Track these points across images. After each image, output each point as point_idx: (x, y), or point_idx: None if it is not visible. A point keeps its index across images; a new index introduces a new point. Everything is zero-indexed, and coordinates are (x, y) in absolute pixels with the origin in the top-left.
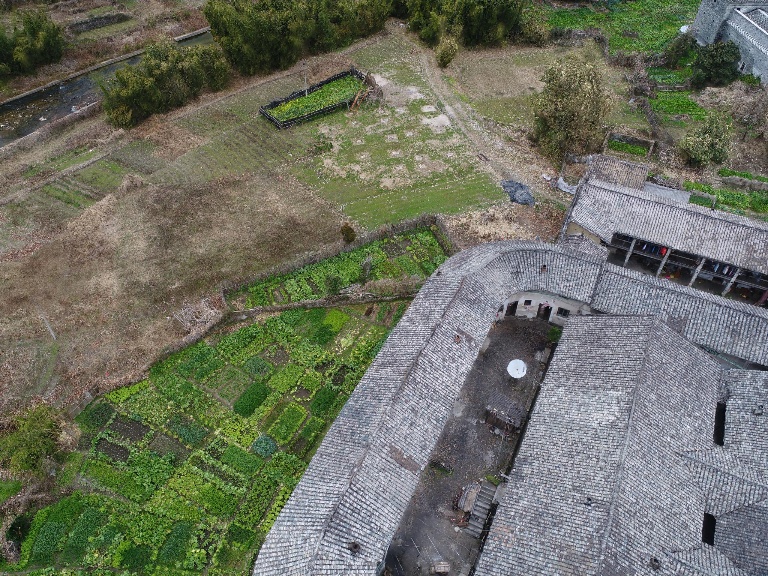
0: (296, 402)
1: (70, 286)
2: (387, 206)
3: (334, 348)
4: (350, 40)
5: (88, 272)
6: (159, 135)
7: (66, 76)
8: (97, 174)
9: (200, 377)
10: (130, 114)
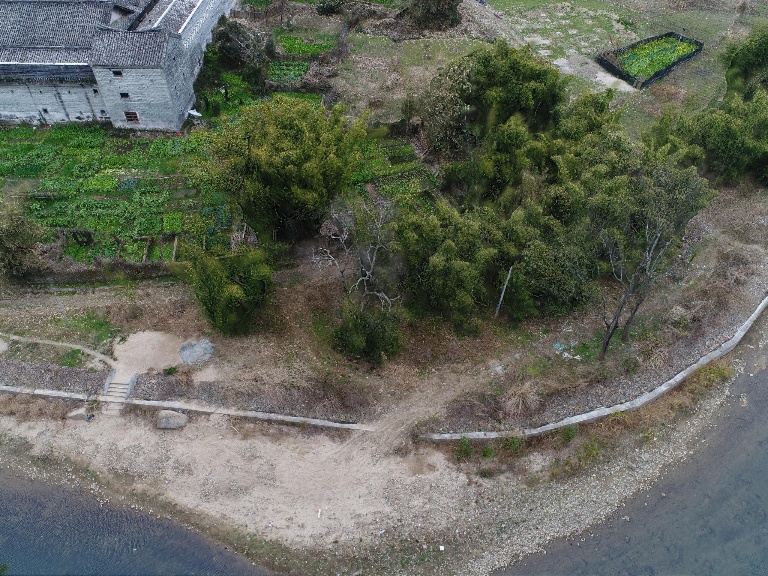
0: None
1: None
2: None
3: None
4: None
5: None
6: None
7: None
8: None
9: None
10: None
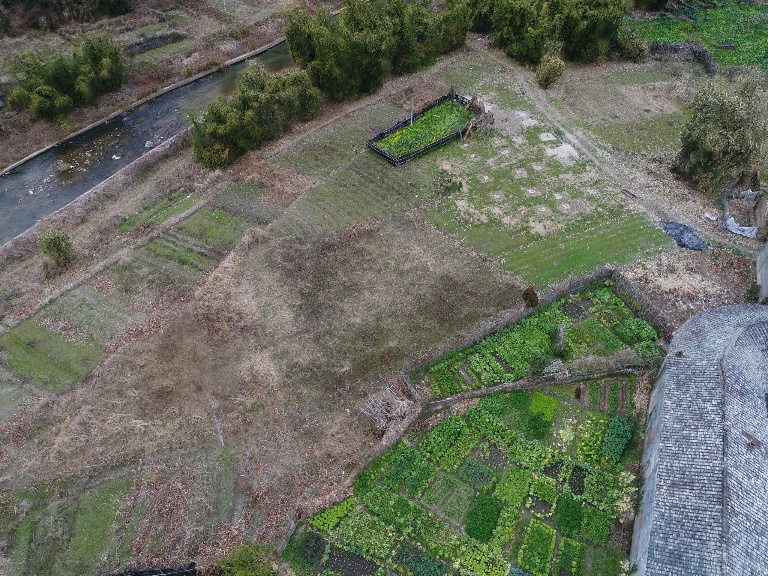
0: (537, 519)
1: (219, 373)
2: (546, 256)
3: (556, 443)
4: (434, 58)
5: (235, 353)
6: (262, 176)
7: (129, 105)
8: (204, 226)
9: (414, 490)
10: (227, 153)
